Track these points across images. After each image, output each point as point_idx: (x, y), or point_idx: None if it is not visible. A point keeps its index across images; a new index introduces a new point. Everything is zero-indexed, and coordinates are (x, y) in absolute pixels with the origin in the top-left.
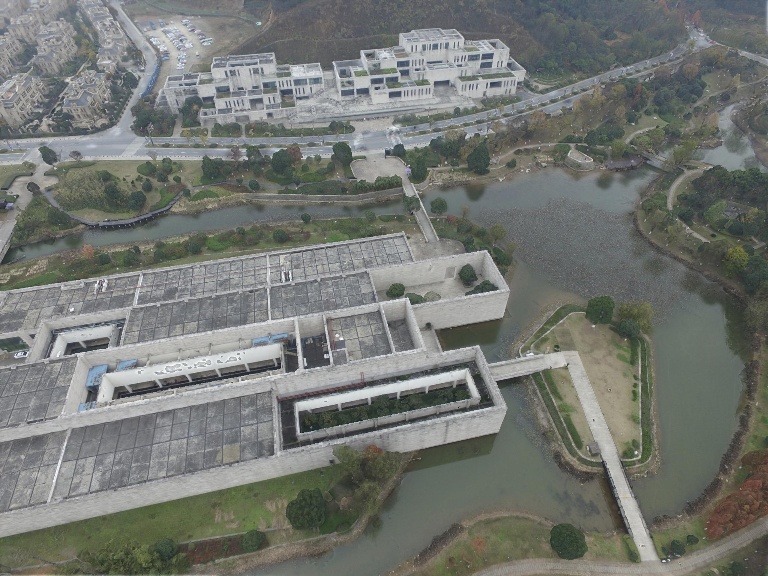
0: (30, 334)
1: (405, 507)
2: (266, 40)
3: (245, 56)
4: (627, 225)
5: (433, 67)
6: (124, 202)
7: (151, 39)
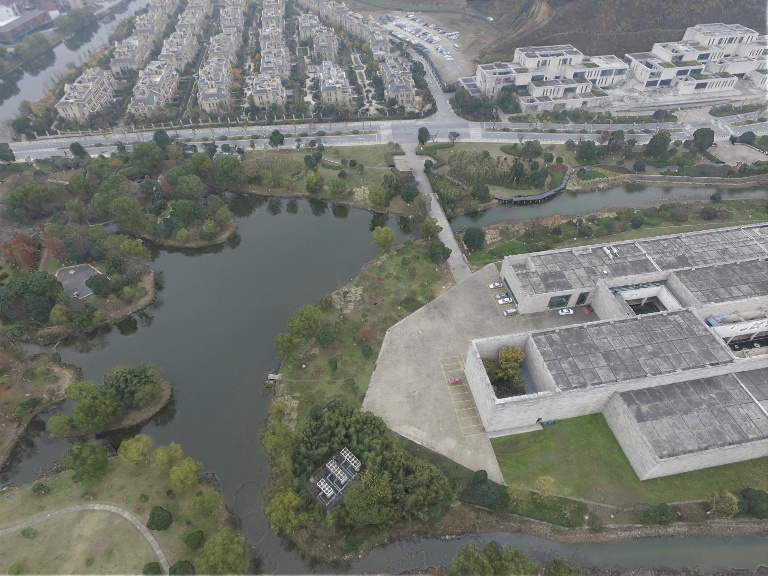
0: (582, 292)
1: None
2: (544, 33)
3: (545, 47)
4: None
5: (733, 60)
6: (527, 179)
7: (393, 32)
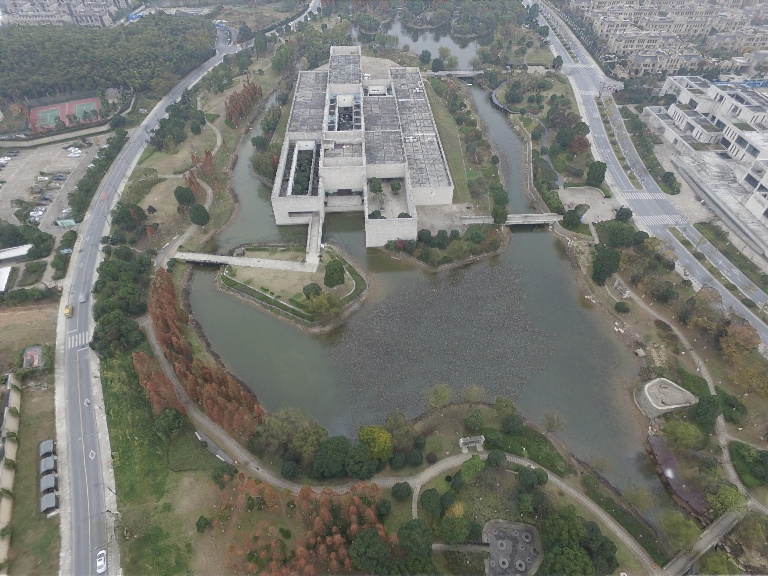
0: None
1: (265, 204)
2: None
3: (765, 99)
4: (491, 394)
5: None
6: None
7: None
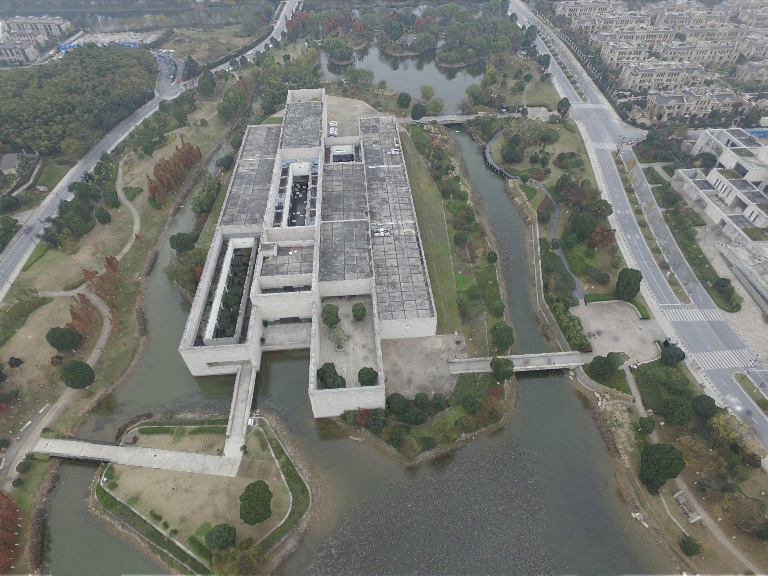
0: None
1: None
2: None
3: None
4: None
5: None
6: None
7: None
